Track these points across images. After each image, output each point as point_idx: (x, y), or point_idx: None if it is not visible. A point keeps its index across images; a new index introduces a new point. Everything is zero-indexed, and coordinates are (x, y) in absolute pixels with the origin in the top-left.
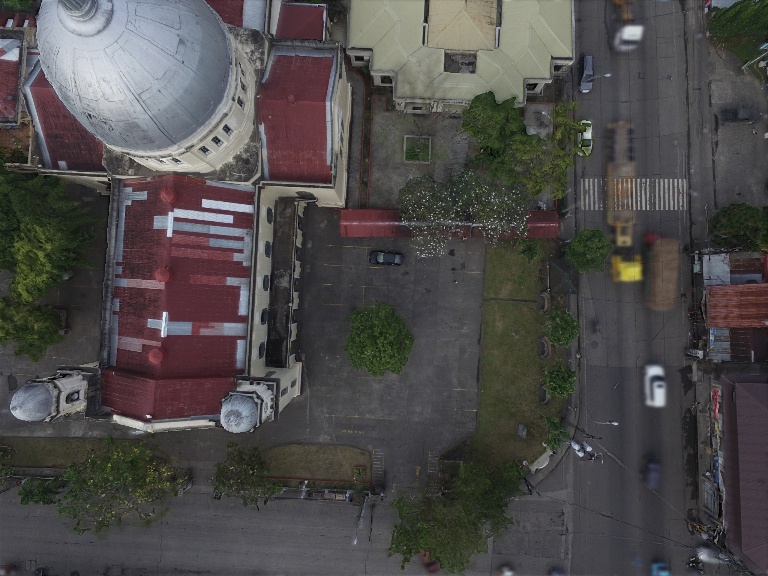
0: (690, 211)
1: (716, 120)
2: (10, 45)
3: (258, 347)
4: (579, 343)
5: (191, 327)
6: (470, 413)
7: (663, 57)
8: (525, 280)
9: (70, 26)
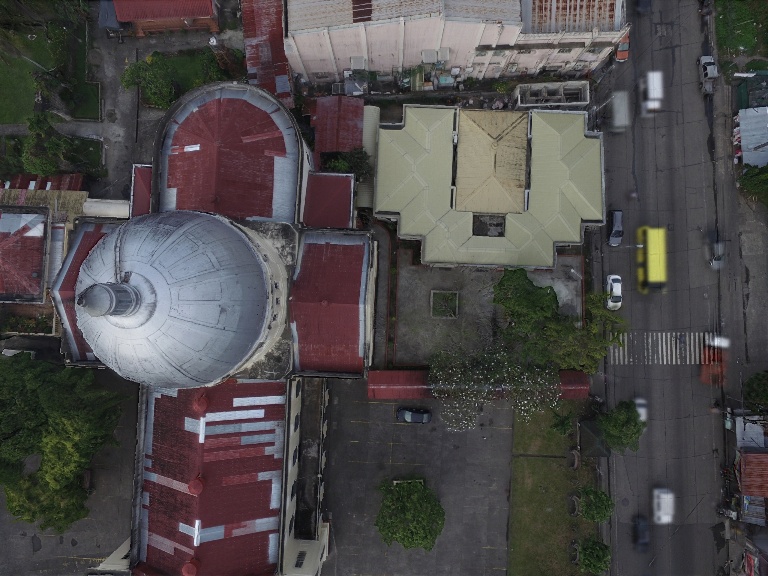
0: (721, 365)
1: (747, 273)
2: (35, 221)
3: (288, 528)
4: None
5: (223, 530)
6: (500, 572)
7: (692, 208)
8: (554, 436)
9: (113, 320)
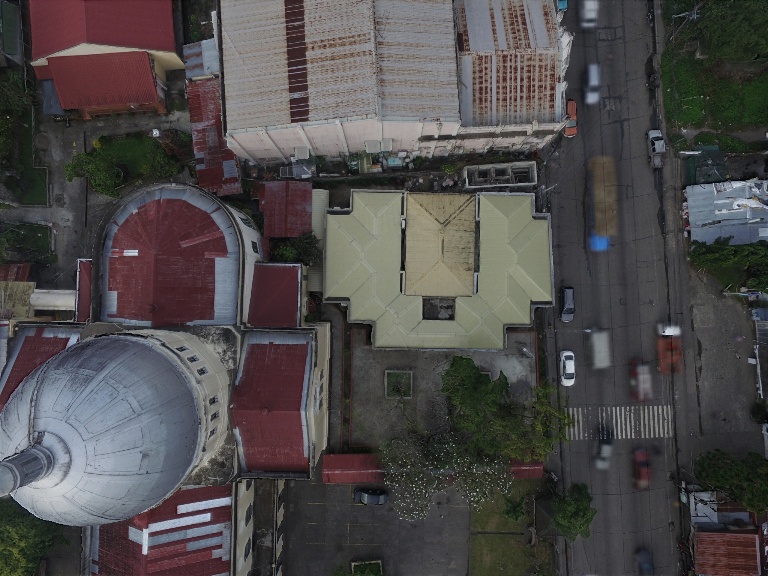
0: (676, 437)
1: (699, 345)
2: None
3: None
4: (568, 575)
5: None
6: None
7: (644, 281)
8: None
9: None
